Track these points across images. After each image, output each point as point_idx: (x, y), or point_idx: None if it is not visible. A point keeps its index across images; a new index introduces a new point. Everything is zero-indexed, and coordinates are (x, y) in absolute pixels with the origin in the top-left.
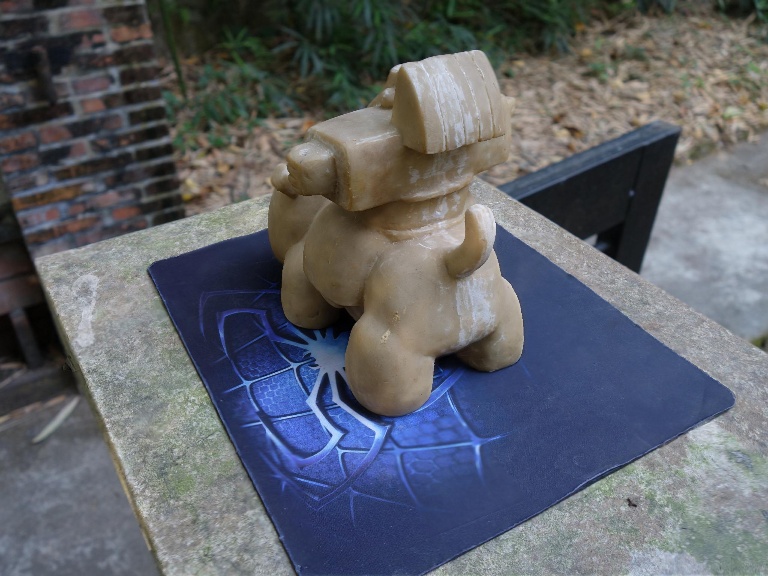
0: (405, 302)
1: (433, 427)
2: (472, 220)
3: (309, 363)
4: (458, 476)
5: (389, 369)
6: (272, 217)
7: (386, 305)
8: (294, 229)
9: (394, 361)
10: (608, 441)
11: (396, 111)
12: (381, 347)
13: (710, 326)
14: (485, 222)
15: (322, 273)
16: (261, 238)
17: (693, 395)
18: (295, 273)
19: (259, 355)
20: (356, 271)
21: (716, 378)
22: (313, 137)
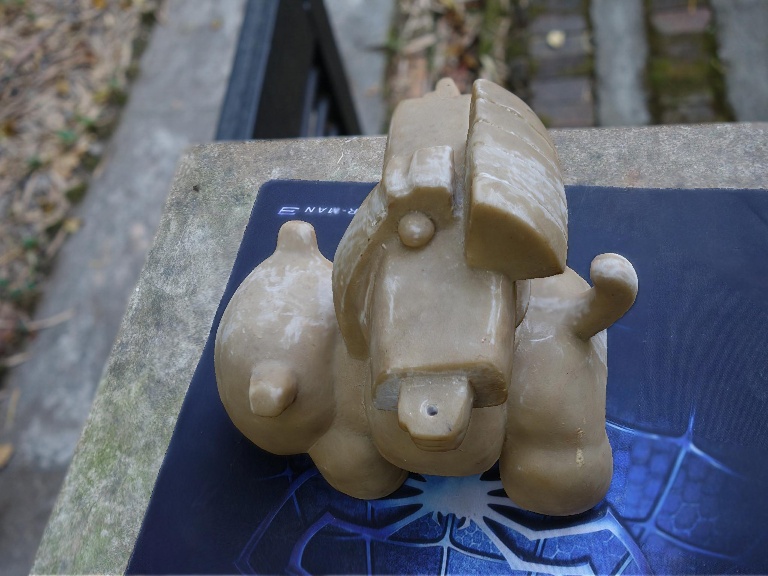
0: (580, 413)
1: (639, 469)
2: (618, 285)
3: (454, 525)
4: (720, 494)
5: (598, 478)
6: (263, 434)
7: (561, 433)
8: (315, 427)
9: (598, 467)
10: (759, 331)
11: (480, 253)
12: (582, 471)
13: (667, 134)
14: (631, 275)
15: (455, 464)
16: (189, 430)
17: (749, 220)
18: (358, 465)
19: (399, 570)
20: (496, 430)
21: (734, 185)
22: (406, 376)
